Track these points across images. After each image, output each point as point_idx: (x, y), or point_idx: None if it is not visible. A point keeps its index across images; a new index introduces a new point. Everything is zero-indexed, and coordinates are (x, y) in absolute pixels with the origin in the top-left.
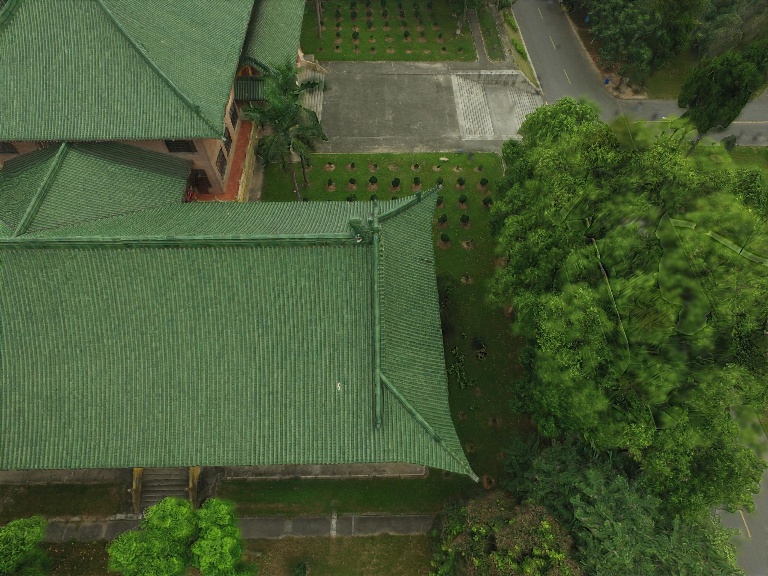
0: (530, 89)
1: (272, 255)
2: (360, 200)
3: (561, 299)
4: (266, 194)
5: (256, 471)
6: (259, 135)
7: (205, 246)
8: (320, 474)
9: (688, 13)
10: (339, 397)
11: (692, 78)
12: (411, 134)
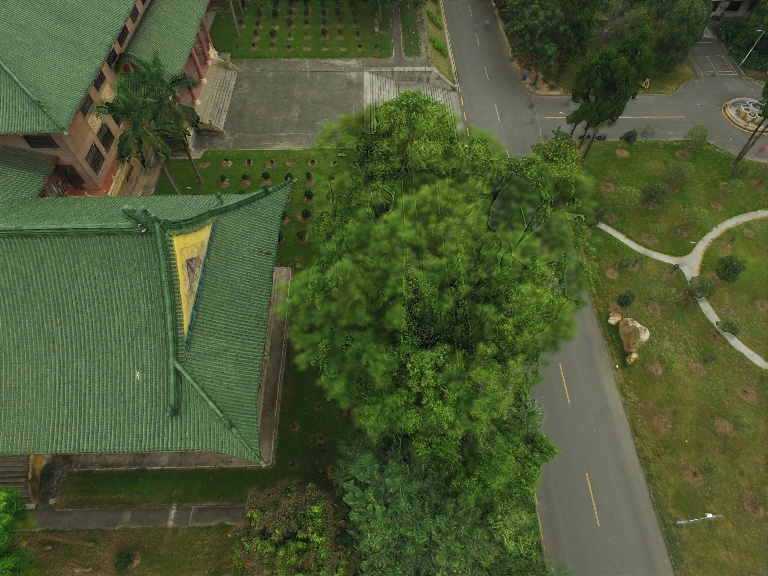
0: (446, 86)
1: (62, 245)
2: None
3: (436, 292)
4: (159, 190)
5: (103, 463)
6: (159, 132)
7: None
8: (166, 465)
9: (588, 9)
10: (138, 386)
11: (580, 73)
12: (314, 130)
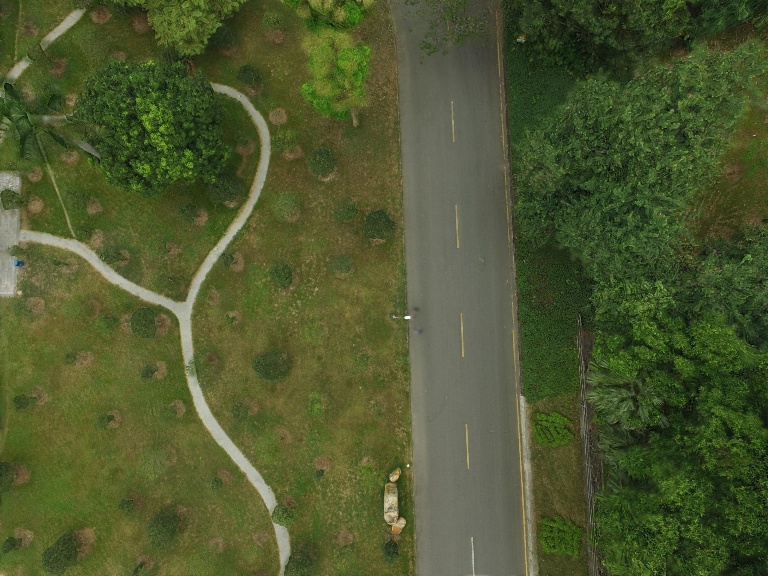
0: None
1: None
2: None
3: None
4: None
5: None
6: None
7: None
8: None
9: None
10: None
11: None
12: None
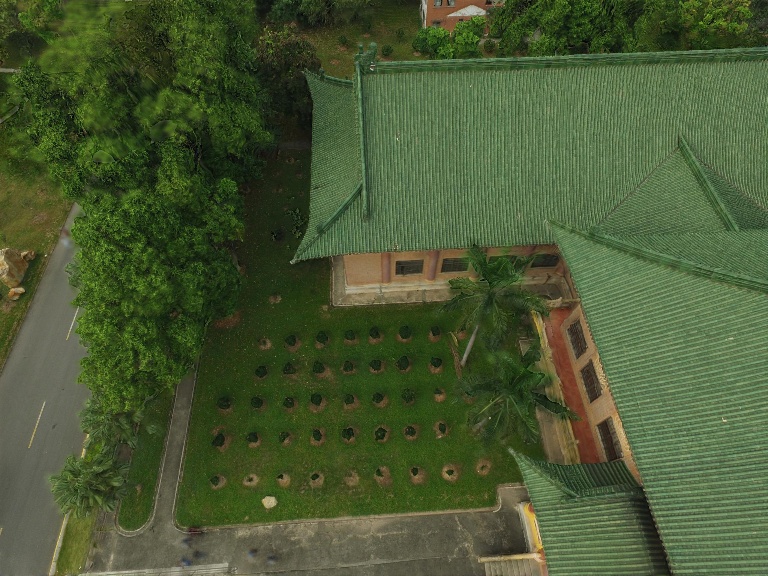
0: None
1: None
2: (397, 407)
3: None
4: None
5: None
6: None
7: None
8: None
9: None
10: None
11: None
12: None
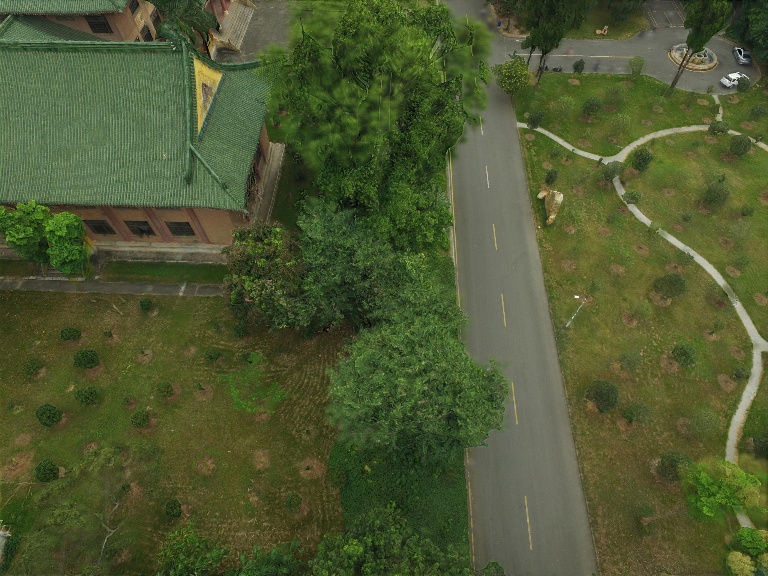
0: None
1: (119, 60)
2: None
3: None
4: None
5: (135, 257)
6: None
7: (74, 51)
8: (180, 260)
9: None
10: (165, 163)
11: (529, 2)
12: None
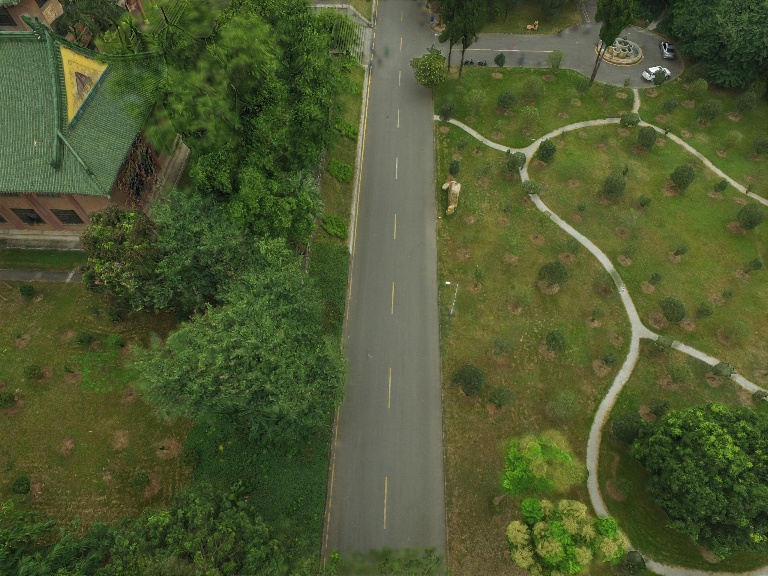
0: (362, 22)
1: None
2: None
3: None
4: None
5: (28, 245)
6: None
7: None
8: (73, 248)
9: None
10: (35, 150)
11: None
12: None
